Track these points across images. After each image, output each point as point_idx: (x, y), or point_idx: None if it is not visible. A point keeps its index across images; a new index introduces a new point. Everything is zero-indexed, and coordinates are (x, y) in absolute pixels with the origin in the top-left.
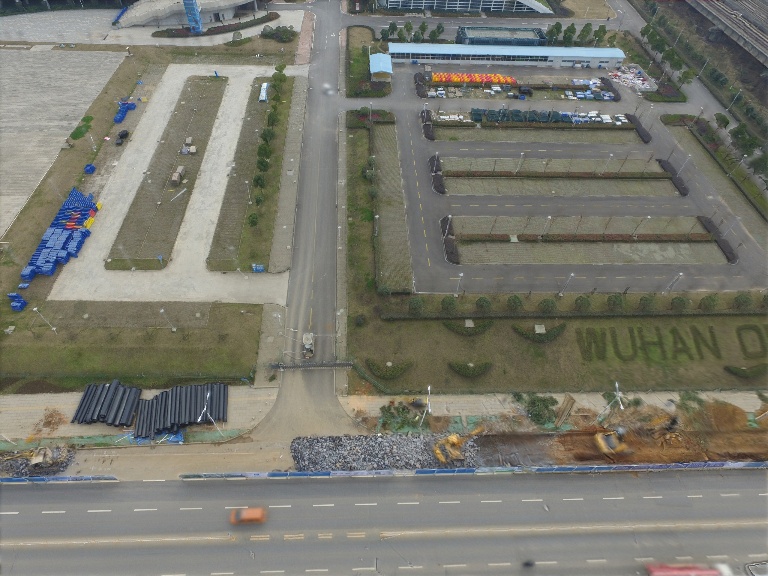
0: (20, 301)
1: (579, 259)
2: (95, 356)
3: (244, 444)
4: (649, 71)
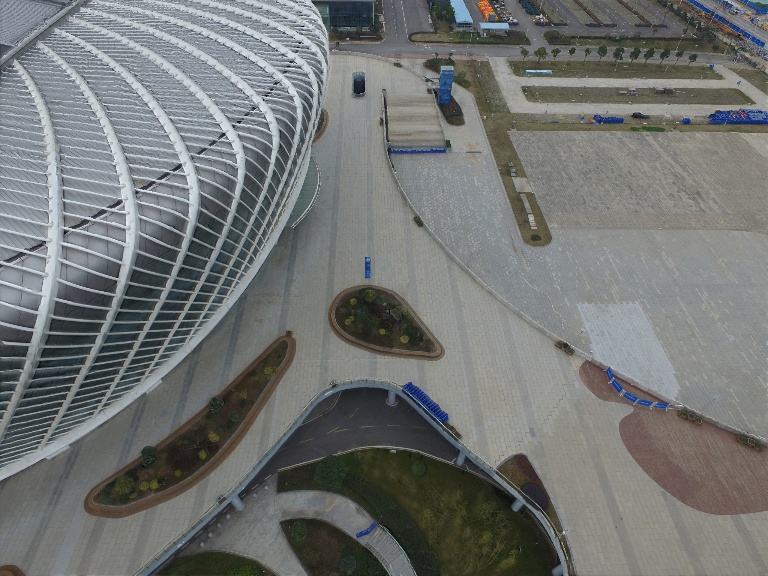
0: None
1: None
2: None
3: None
4: None
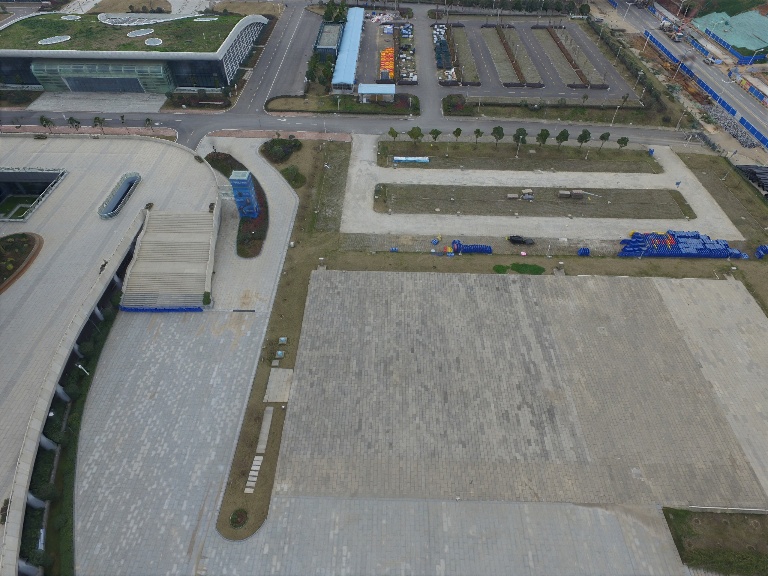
0: (763, 246)
1: (584, 58)
2: (766, 209)
3: (761, 161)
4: (375, 9)
